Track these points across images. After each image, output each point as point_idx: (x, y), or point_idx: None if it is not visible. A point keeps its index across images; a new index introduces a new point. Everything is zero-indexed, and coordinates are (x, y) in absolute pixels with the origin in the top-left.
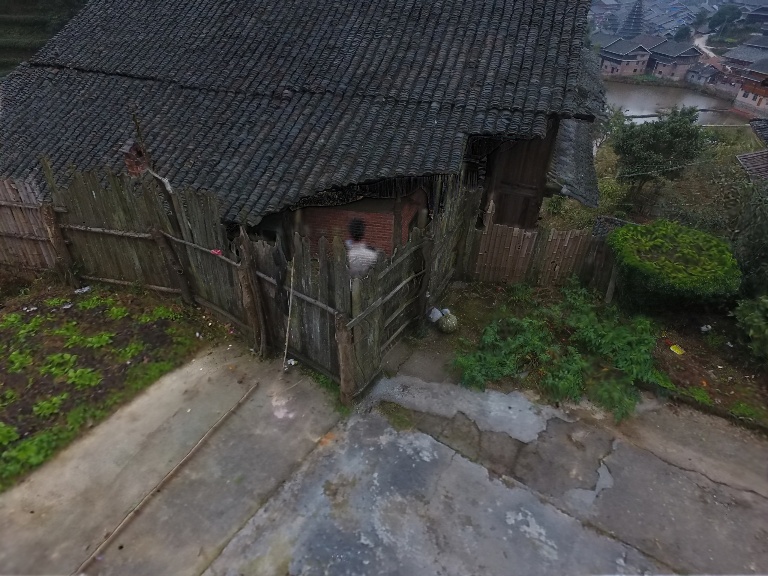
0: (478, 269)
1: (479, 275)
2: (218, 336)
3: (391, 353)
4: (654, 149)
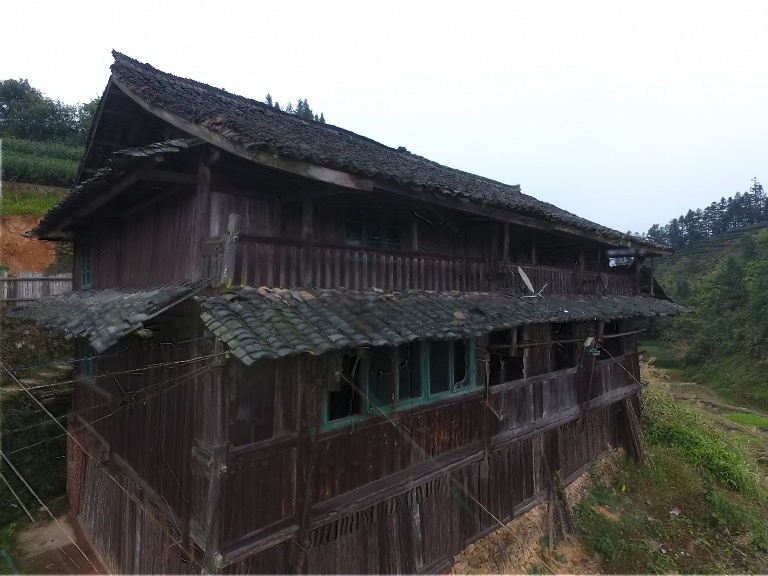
0: None
1: None
2: None
3: None
4: None
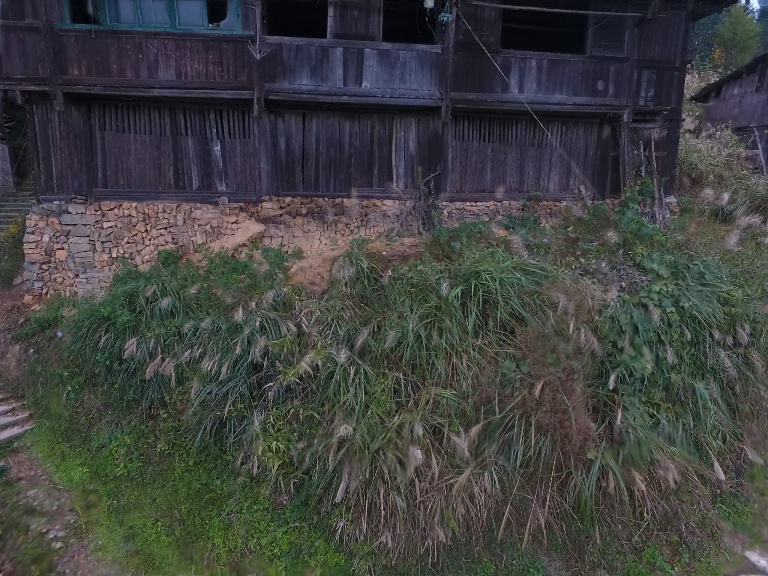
0: None
1: None
2: None
3: None
4: None
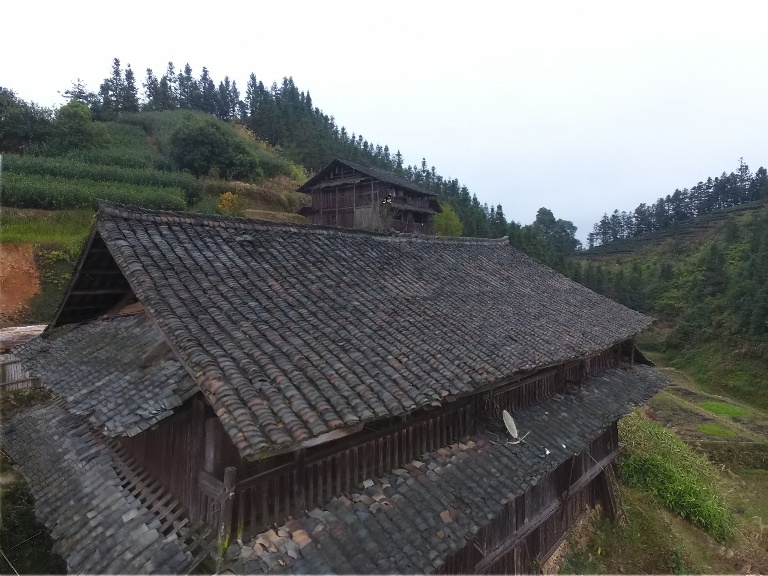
0: None
1: None
2: None
3: None
4: None
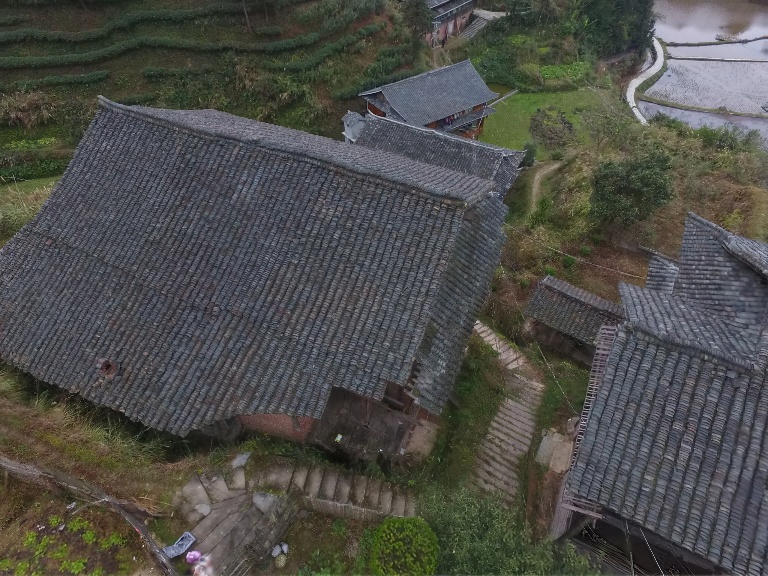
0: (315, 508)
1: (316, 510)
2: (146, 559)
3: None
4: (626, 191)
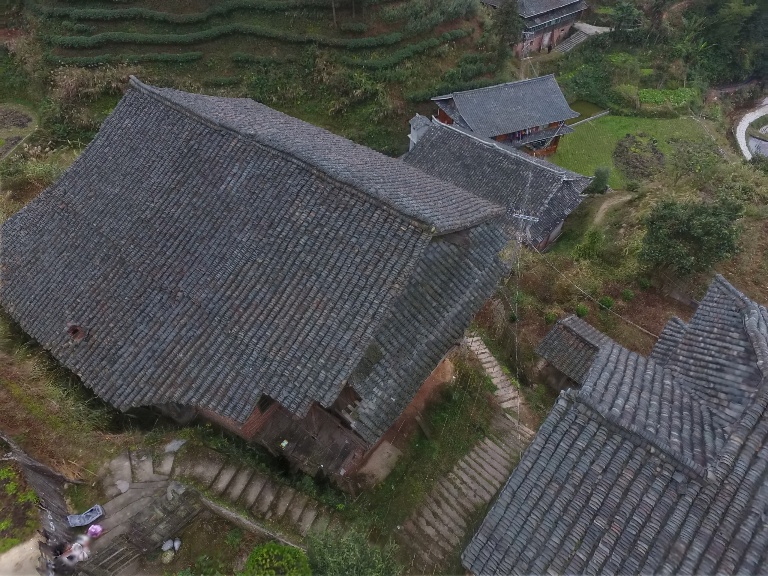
0: (216, 512)
1: None
2: None
3: (124, 571)
4: (685, 236)
